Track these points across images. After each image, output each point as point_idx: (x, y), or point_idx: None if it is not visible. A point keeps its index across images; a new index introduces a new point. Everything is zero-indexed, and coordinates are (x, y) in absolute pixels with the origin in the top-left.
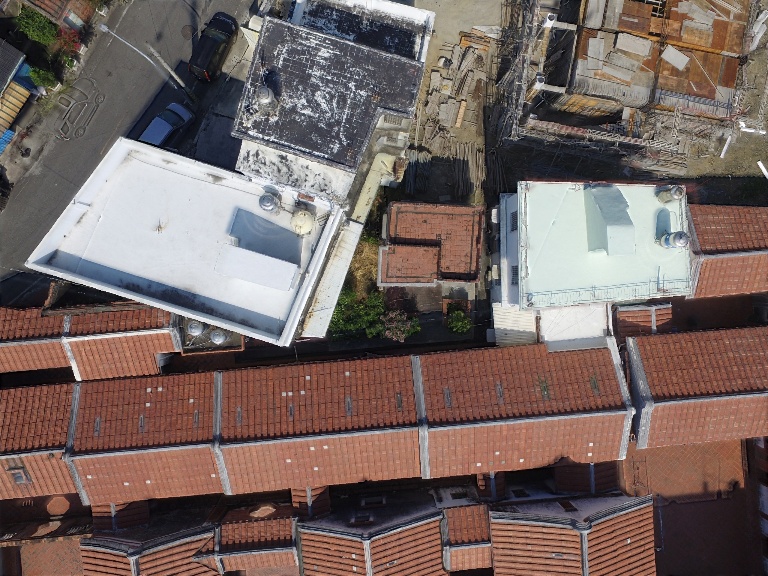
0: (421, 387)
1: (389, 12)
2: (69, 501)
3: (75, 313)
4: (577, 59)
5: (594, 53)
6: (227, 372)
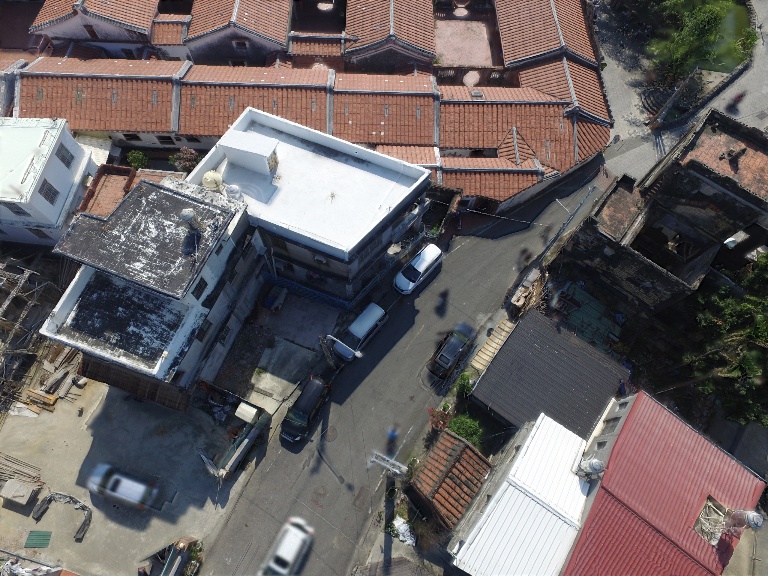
0: (173, 107)
1: None
2: None
3: None
4: None
5: None
6: None
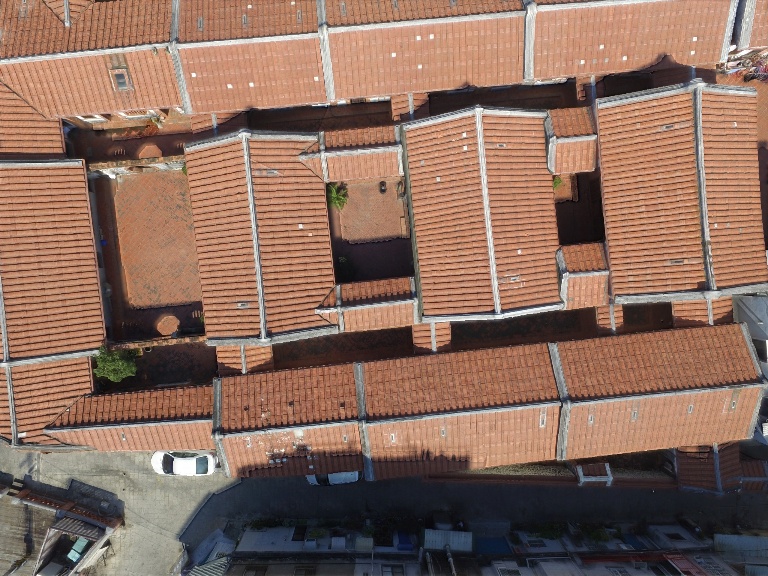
0: None
1: None
2: (161, 150)
3: None
4: None
5: None
6: None
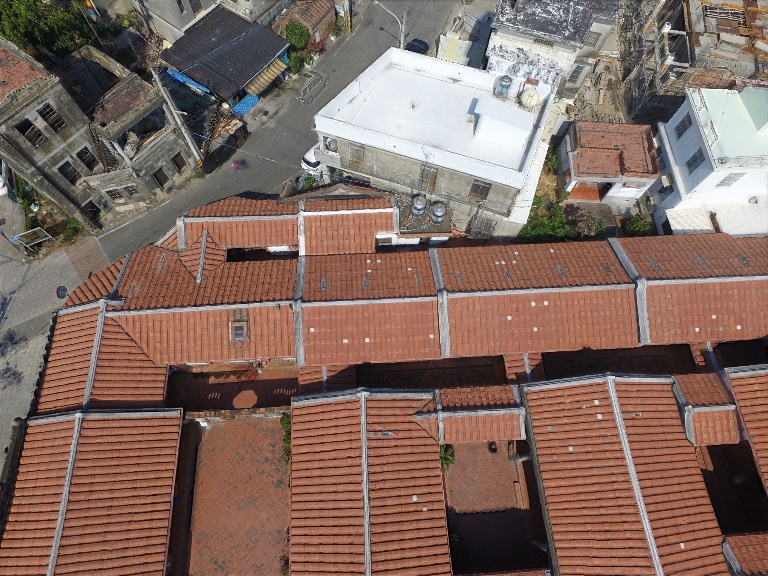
0: (626, 256)
1: None
2: (257, 395)
3: (311, 197)
4: (693, 47)
5: (705, 44)
6: (441, 248)
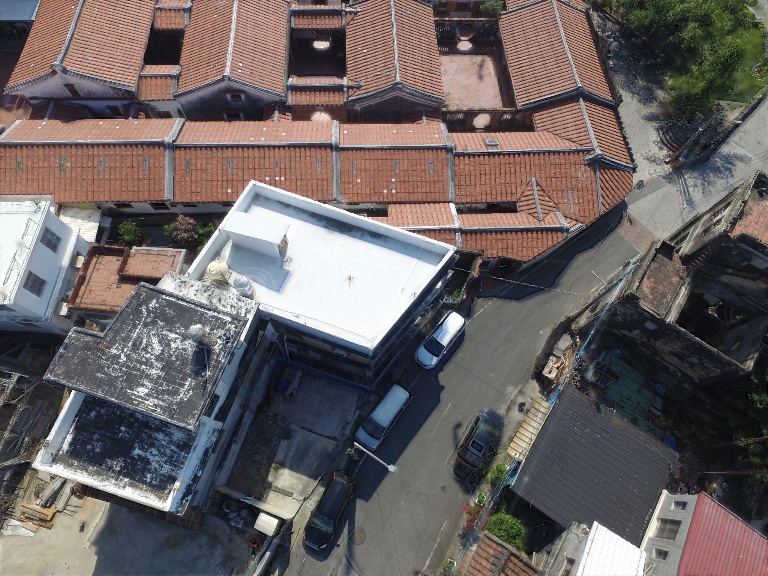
0: (167, 174)
1: (88, 479)
2: None
3: None
4: None
5: None
6: (329, 199)
